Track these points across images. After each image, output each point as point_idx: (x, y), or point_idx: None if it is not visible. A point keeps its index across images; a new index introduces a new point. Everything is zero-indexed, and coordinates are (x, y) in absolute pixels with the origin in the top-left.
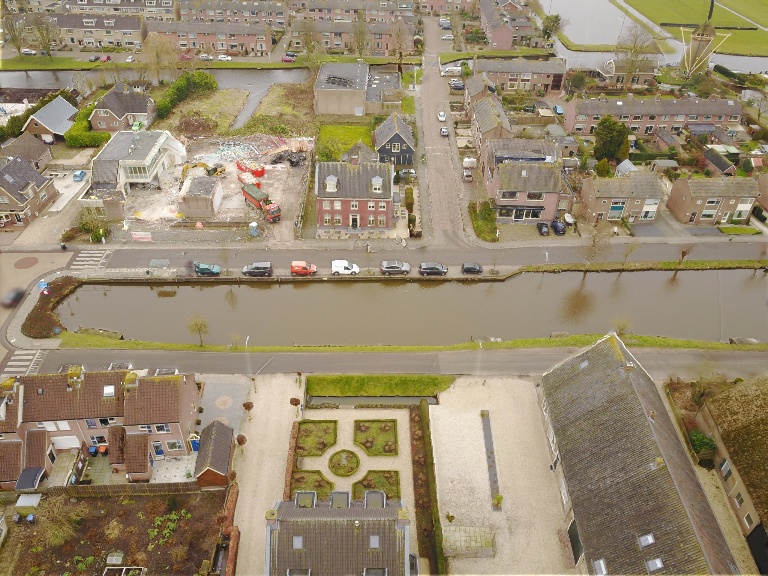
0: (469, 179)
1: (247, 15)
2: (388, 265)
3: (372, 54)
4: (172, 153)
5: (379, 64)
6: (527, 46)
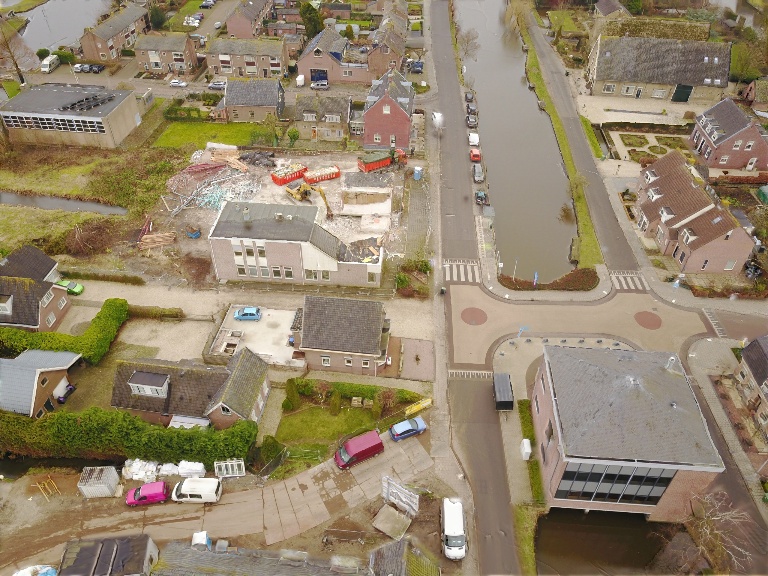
0: None
1: None
2: (474, 119)
3: None
4: None
5: None
6: None
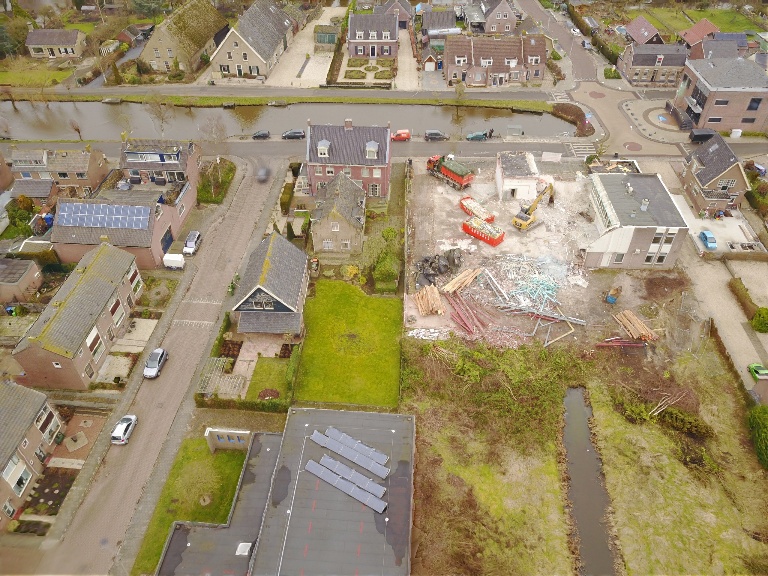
0: None
1: None
2: None
3: None
4: None
5: None
6: None
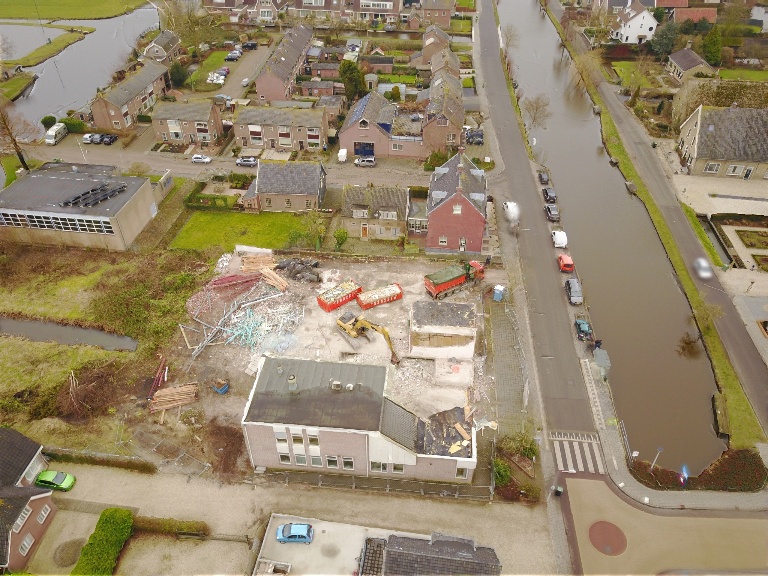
0: None
1: None
2: (556, 211)
3: None
4: None
5: None
6: None
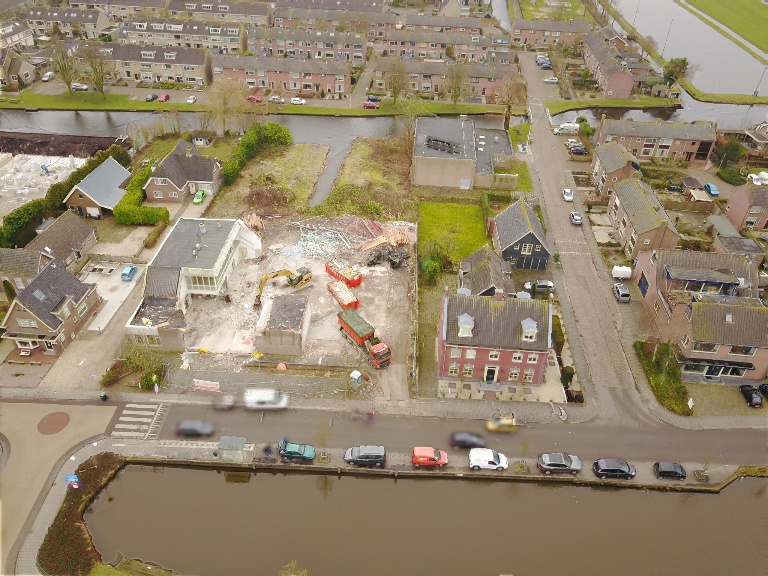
0: (626, 299)
1: (321, 47)
2: (551, 461)
3: (467, 100)
4: (244, 246)
5: (476, 113)
6: (647, 94)
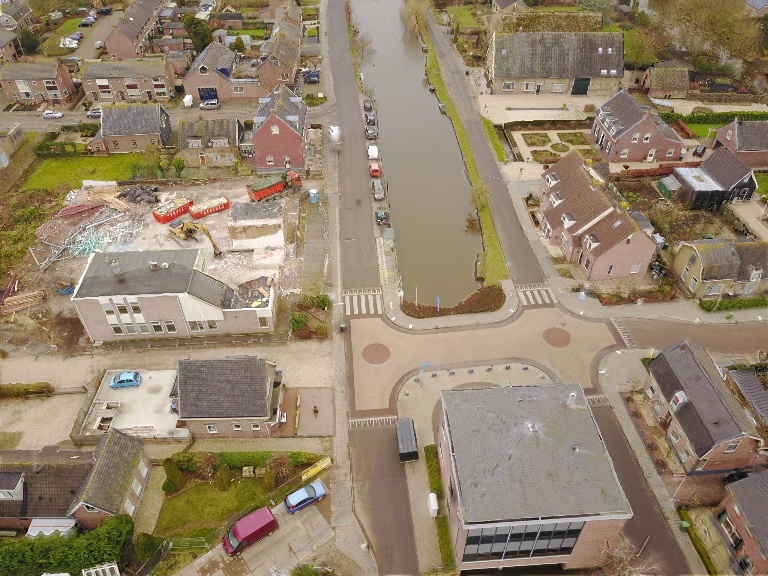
0: None
1: None
2: None
3: None
4: None
5: None
6: None
